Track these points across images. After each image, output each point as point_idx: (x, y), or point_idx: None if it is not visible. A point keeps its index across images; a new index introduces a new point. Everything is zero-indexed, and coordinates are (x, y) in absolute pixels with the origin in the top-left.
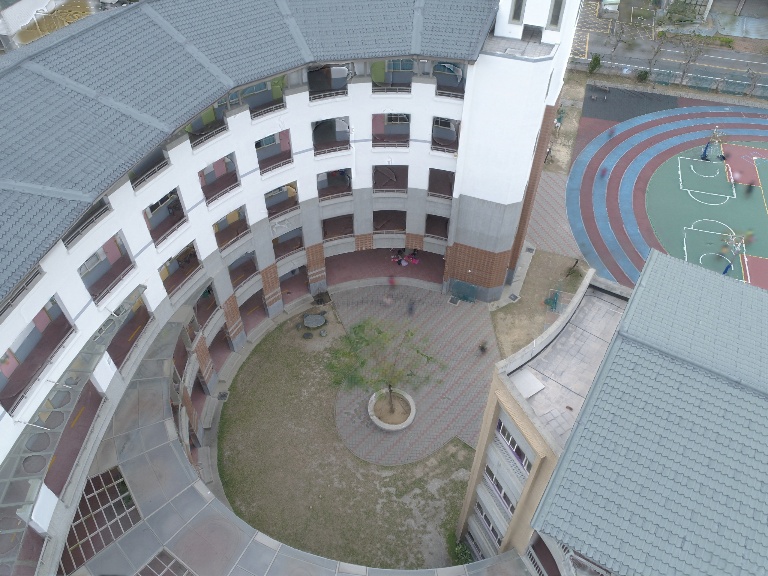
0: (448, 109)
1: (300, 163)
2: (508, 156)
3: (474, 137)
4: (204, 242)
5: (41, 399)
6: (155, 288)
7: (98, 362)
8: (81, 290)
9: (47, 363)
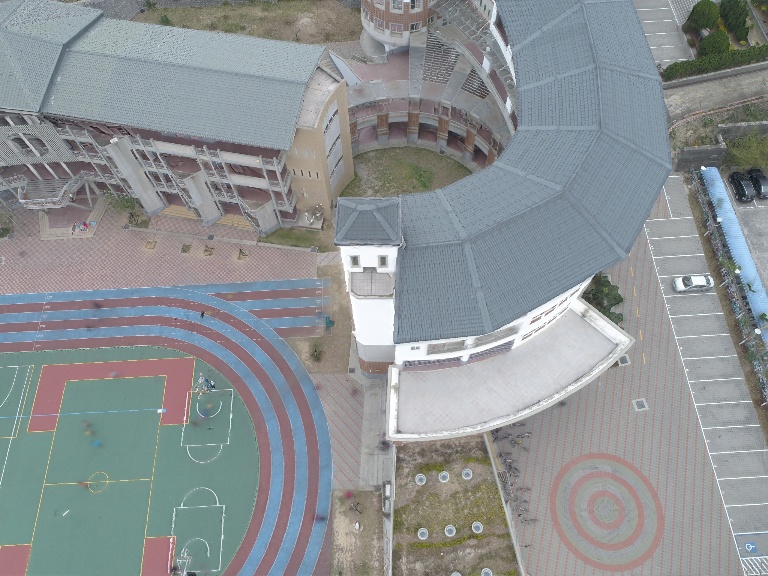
0: None
1: None
2: None
3: None
4: None
5: None
6: None
7: None
8: None
9: None
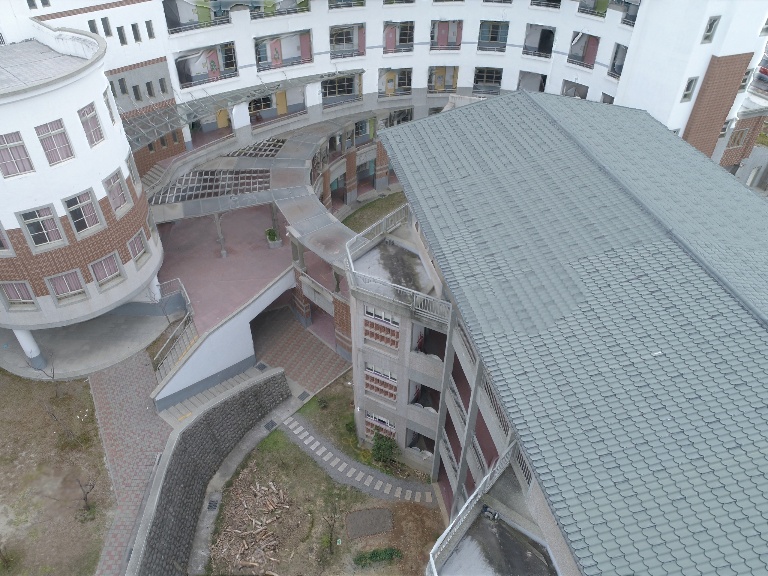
0: (626, 36)
1: (510, 55)
2: (656, 87)
3: (637, 66)
4: (418, 75)
5: (276, 80)
6: (371, 80)
7: (311, 83)
8: (326, 40)
9: (289, 64)
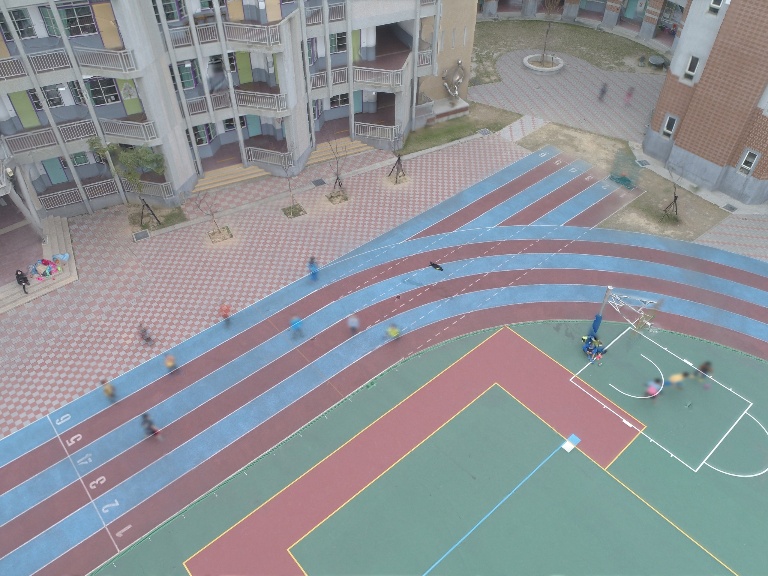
0: None
1: None
2: None
3: None
4: None
5: None
6: None
7: None
8: None
9: None
